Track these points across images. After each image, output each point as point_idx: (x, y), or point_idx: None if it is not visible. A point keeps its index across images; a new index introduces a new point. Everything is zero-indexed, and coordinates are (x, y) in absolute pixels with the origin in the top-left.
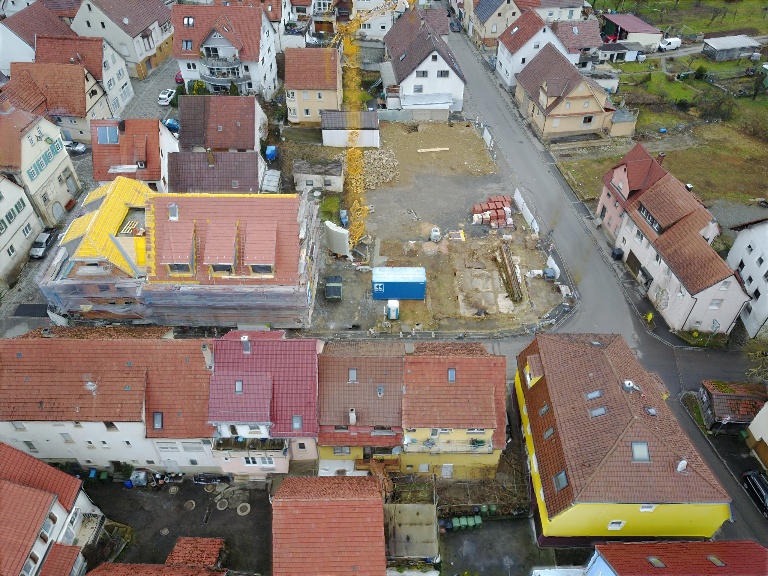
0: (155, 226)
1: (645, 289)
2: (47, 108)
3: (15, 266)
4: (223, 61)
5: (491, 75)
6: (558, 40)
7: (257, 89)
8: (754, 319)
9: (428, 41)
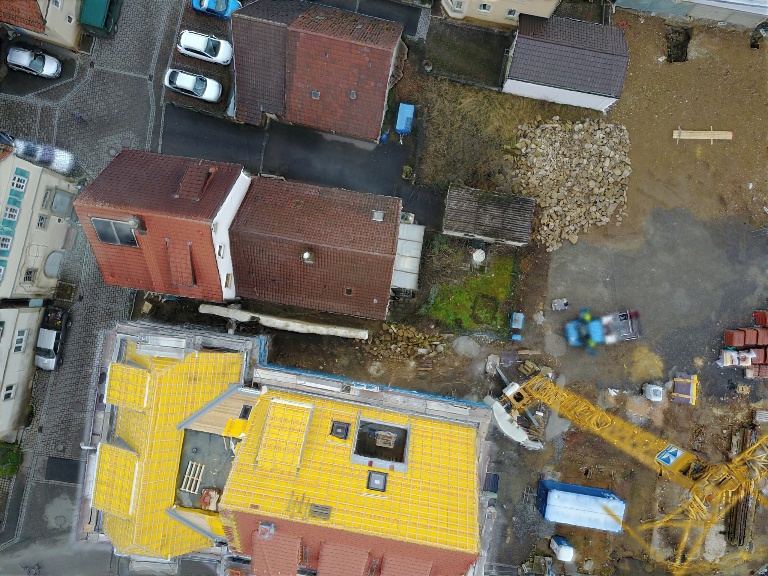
0: (238, 528)
1: None
2: None
3: (21, 398)
4: None
5: None
6: None
7: None
8: None
9: None
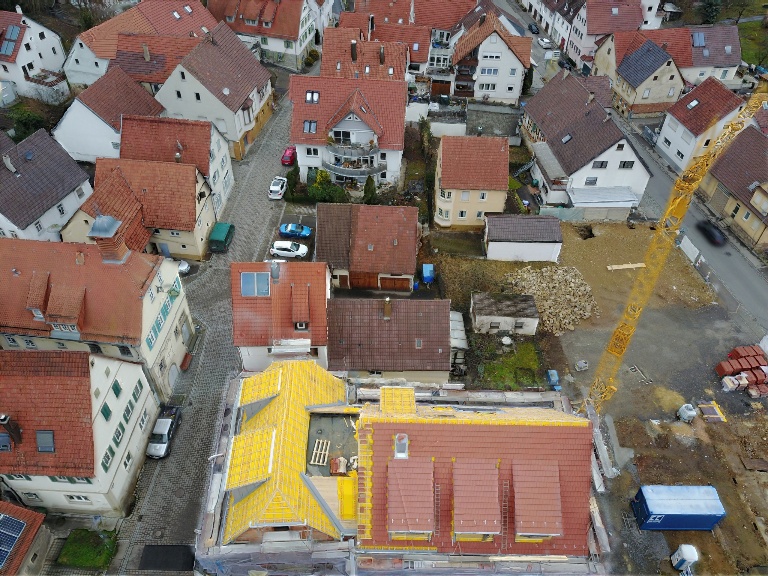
0: (373, 466)
1: None
2: (143, 218)
3: (131, 480)
4: (359, 150)
5: (652, 153)
6: (754, 120)
7: (393, 181)
8: None
9: (608, 124)
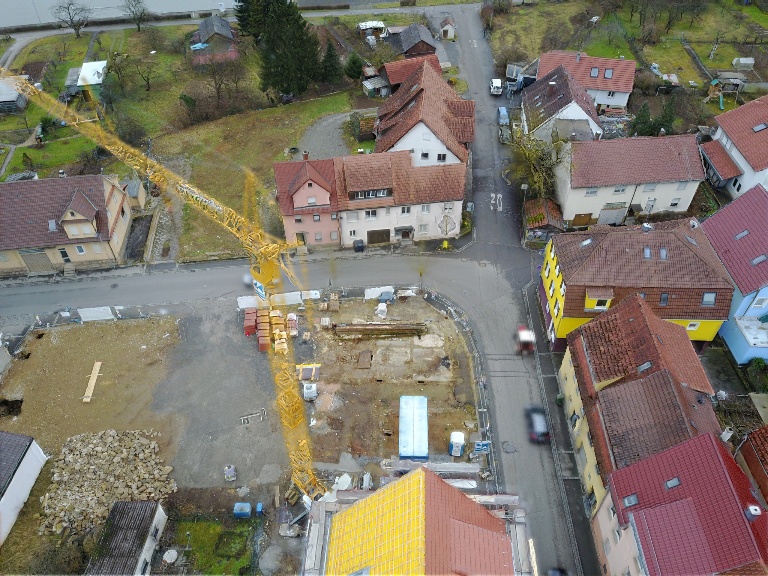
0: None
1: (407, 240)
2: None
3: None
4: None
5: None
6: None
7: None
8: None
9: None
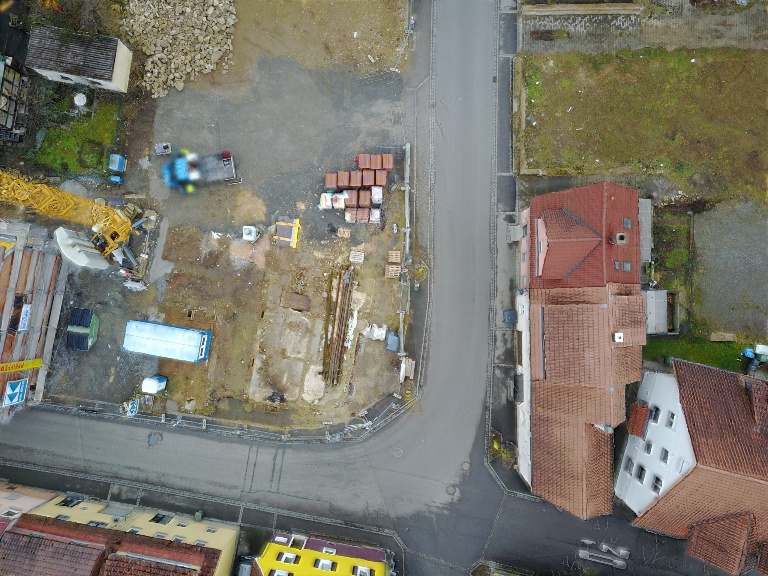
0: None
1: None
2: None
3: None
4: None
5: None
6: None
7: None
8: (626, 488)
9: None
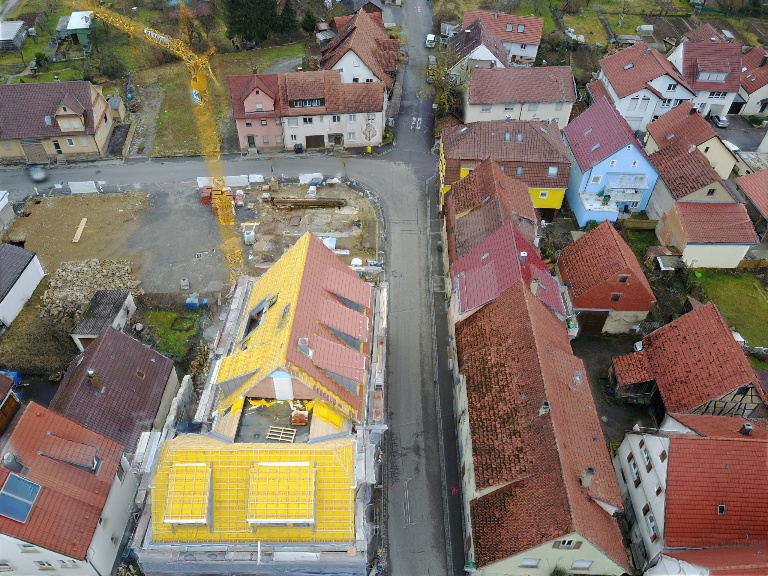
0: (314, 378)
1: (339, 146)
2: None
3: None
4: None
5: None
6: None
7: None
8: None
9: None
